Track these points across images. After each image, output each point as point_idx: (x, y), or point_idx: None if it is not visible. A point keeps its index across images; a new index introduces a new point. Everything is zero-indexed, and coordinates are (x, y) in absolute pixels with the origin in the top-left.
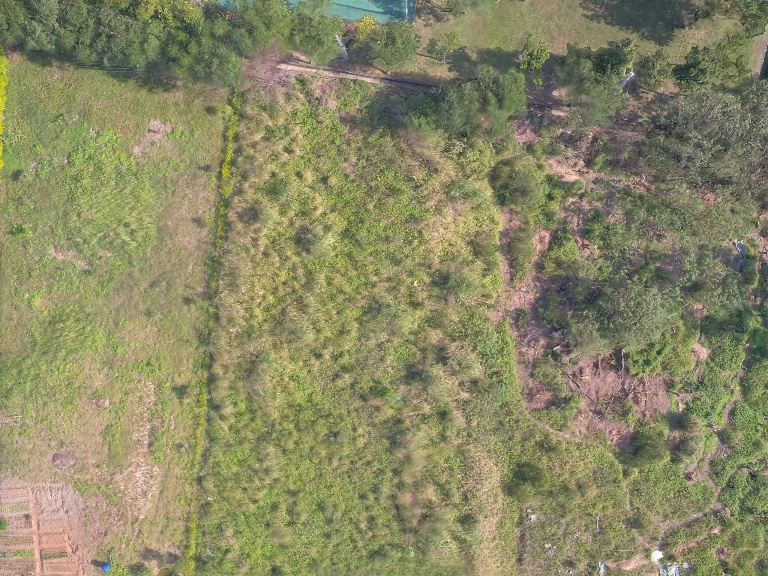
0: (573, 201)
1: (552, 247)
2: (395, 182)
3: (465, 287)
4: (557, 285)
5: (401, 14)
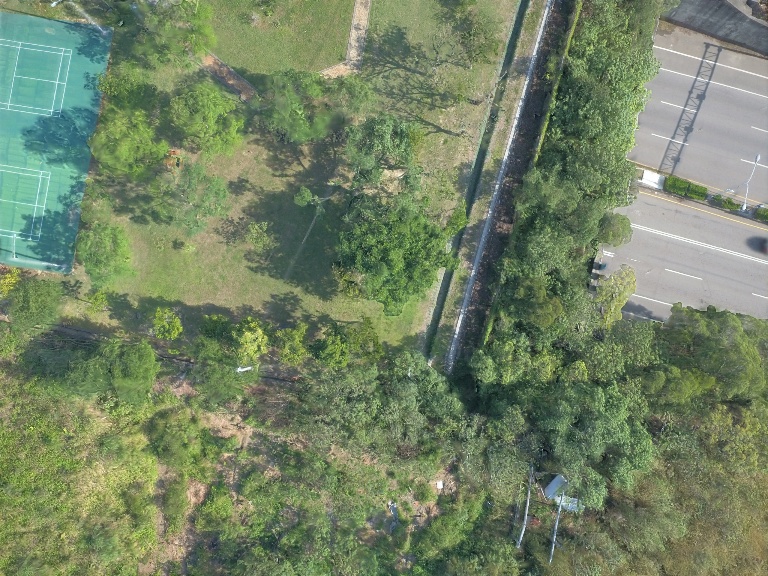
0: (229, 455)
1: (206, 501)
2: (49, 431)
3: (97, 553)
4: (210, 539)
5: (59, 262)
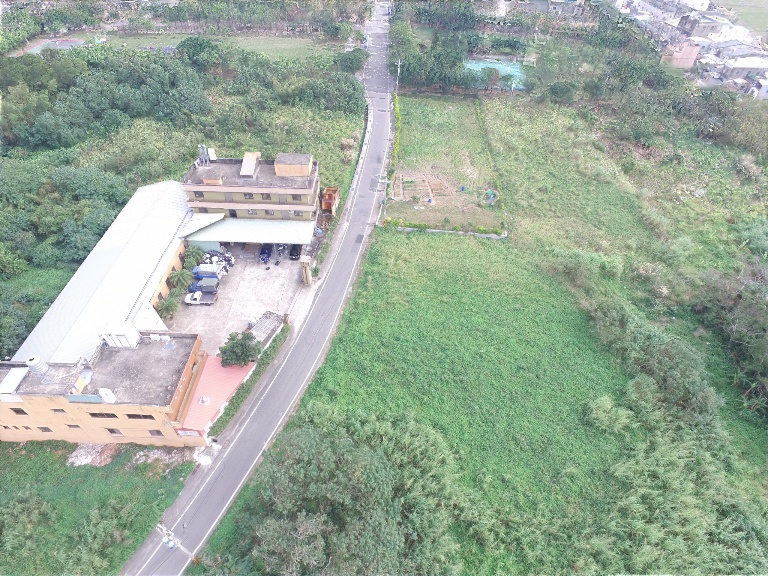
0: None
1: None
2: None
3: None
4: None
5: None
